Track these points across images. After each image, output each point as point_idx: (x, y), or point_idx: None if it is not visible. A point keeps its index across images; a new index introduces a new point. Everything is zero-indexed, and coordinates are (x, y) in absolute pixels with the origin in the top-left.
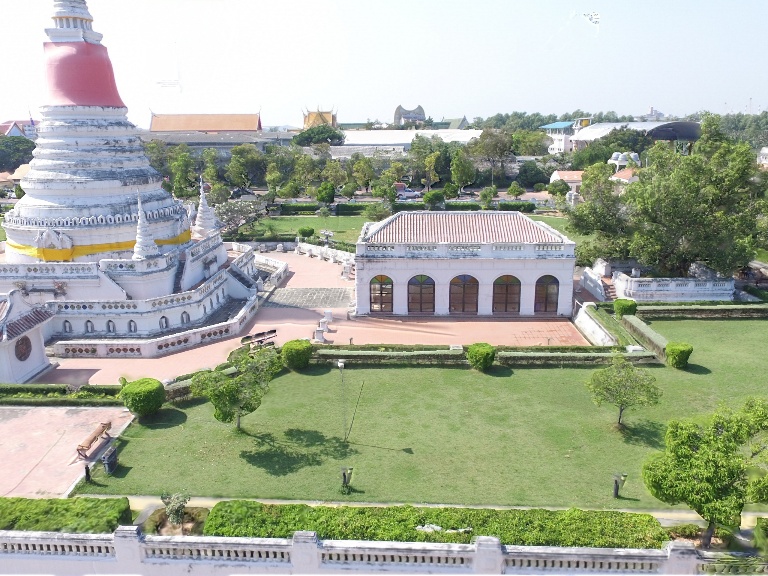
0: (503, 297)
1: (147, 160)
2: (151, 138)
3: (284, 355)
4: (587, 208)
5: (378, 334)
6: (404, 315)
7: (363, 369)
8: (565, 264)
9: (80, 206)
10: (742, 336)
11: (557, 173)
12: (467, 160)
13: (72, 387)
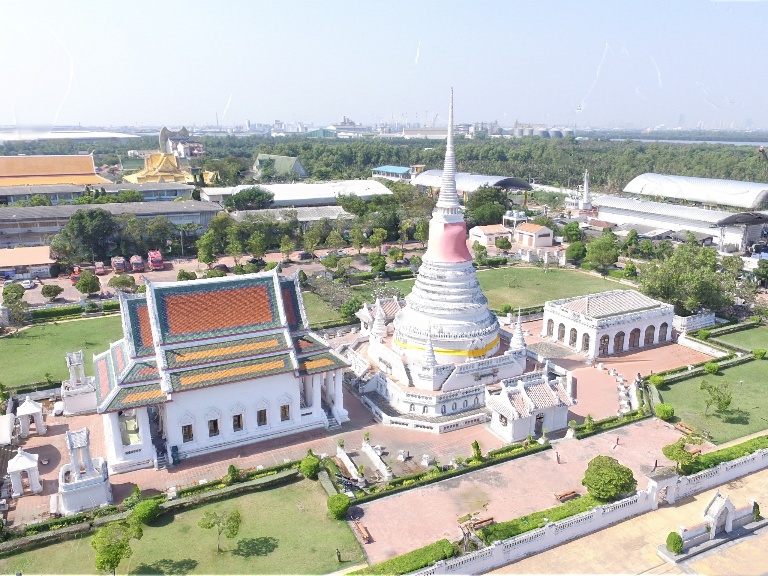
0: (648, 336)
1: None
2: (106, 209)
3: (657, 384)
4: (659, 284)
5: (625, 366)
6: (613, 353)
7: (677, 383)
8: (671, 316)
9: (480, 321)
10: (751, 340)
11: (480, 228)
12: (427, 223)
13: (618, 416)
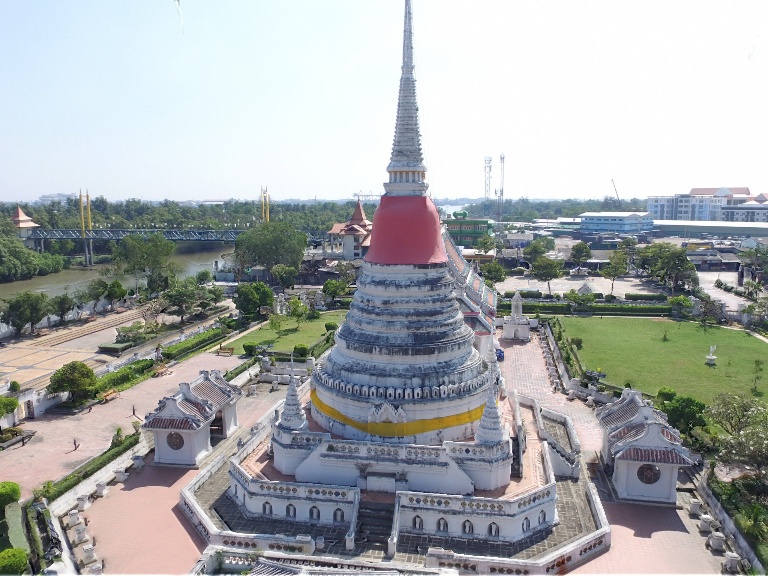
0: None
1: (401, 327)
2: None
3: None
4: None
5: None
6: None
7: None
8: None
9: None
10: None
11: None
12: None
13: (83, 472)
